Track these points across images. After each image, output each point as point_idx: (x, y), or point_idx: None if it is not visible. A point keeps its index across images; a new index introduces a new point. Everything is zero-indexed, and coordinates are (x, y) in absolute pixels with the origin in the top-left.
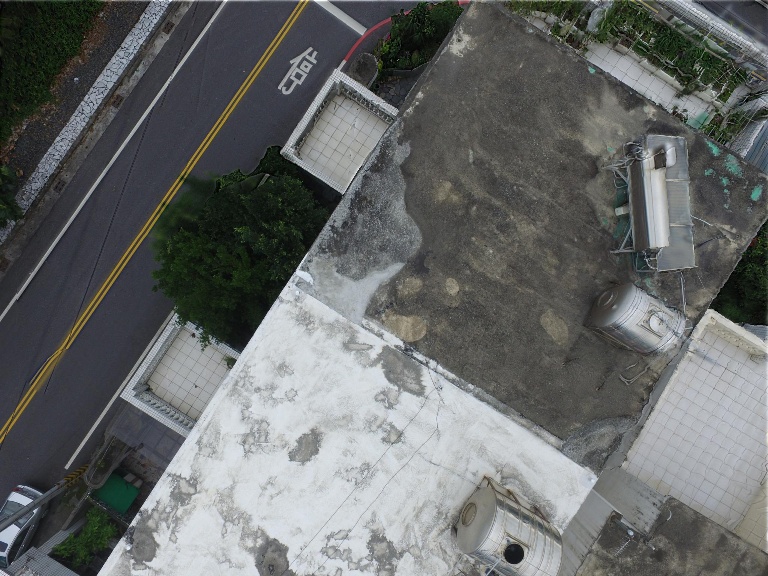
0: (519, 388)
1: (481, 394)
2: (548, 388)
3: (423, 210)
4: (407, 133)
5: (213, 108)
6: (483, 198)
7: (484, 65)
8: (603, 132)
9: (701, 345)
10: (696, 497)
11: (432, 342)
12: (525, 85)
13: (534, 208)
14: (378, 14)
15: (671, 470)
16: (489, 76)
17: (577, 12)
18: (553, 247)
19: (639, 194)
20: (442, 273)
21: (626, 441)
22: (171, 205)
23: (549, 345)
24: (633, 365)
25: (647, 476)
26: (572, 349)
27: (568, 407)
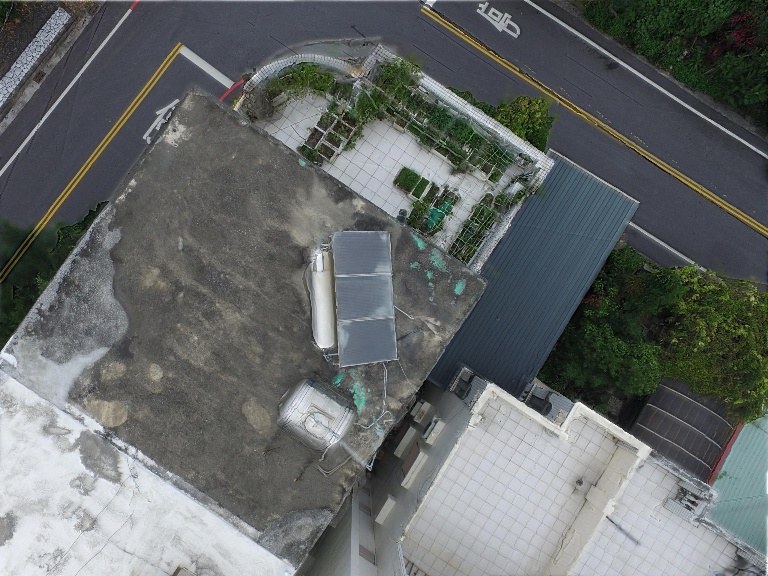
0: (217, 477)
1: (179, 482)
2: (246, 478)
3: (130, 296)
4: (119, 219)
5: (78, 156)
6: (190, 285)
7: (197, 155)
8: (311, 223)
9: (498, 416)
10: (490, 572)
11: (132, 428)
12: (236, 176)
13: (239, 296)
14: (246, 69)
15: (465, 543)
16: (202, 166)
17: (349, 93)
18: (258, 335)
19: (307, 293)
20: (147, 359)
21: (410, 514)
22: (30, 250)
23: (250, 434)
24: (321, 459)
25: (440, 549)
26: (273, 438)
27: (266, 497)
